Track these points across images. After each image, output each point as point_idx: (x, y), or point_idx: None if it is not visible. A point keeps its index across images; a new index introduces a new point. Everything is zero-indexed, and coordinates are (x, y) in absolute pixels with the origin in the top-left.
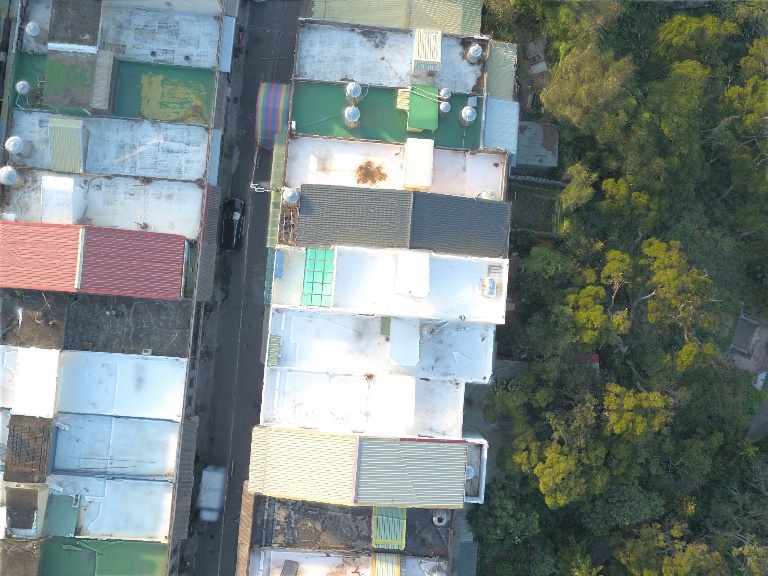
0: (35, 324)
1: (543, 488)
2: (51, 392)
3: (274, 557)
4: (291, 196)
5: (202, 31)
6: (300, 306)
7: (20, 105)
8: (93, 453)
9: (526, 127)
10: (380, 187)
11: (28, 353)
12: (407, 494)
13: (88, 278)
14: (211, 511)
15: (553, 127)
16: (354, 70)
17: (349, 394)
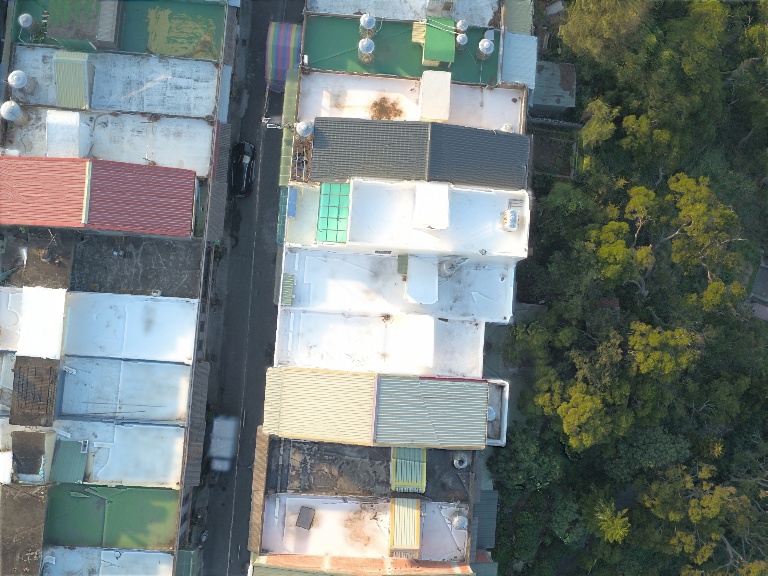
0: (41, 263)
1: (563, 438)
2: (58, 332)
3: (290, 504)
4: (305, 129)
5: None
6: (314, 244)
7: (23, 40)
8: (101, 398)
9: (543, 67)
10: None
11: (34, 292)
12: (427, 434)
13: (95, 213)
14: (222, 463)
15: (570, 67)
16: (367, 4)
17: (365, 336)
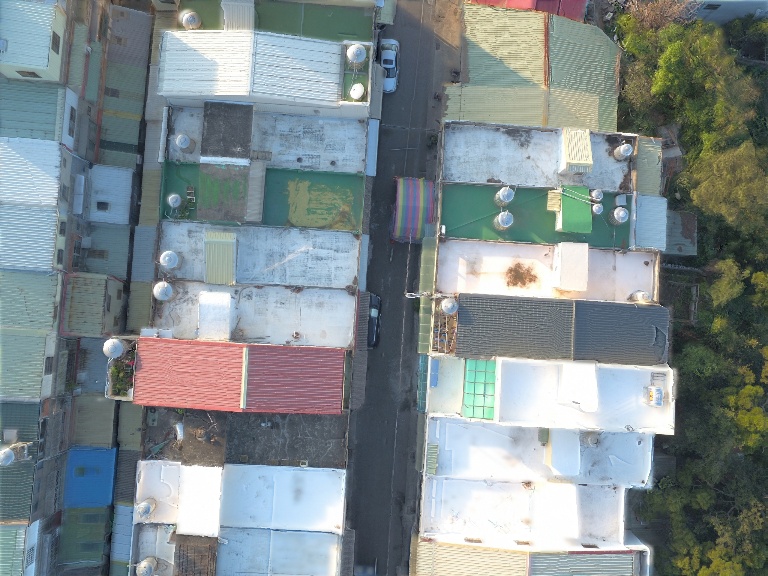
0: (197, 442)
1: None
2: (215, 511)
3: None
4: (451, 307)
5: (347, 135)
6: (457, 414)
7: (169, 216)
8: (253, 567)
9: None
10: (531, 289)
11: (191, 472)
12: None
13: (253, 397)
14: None
15: (691, 215)
16: (500, 170)
17: (506, 501)
